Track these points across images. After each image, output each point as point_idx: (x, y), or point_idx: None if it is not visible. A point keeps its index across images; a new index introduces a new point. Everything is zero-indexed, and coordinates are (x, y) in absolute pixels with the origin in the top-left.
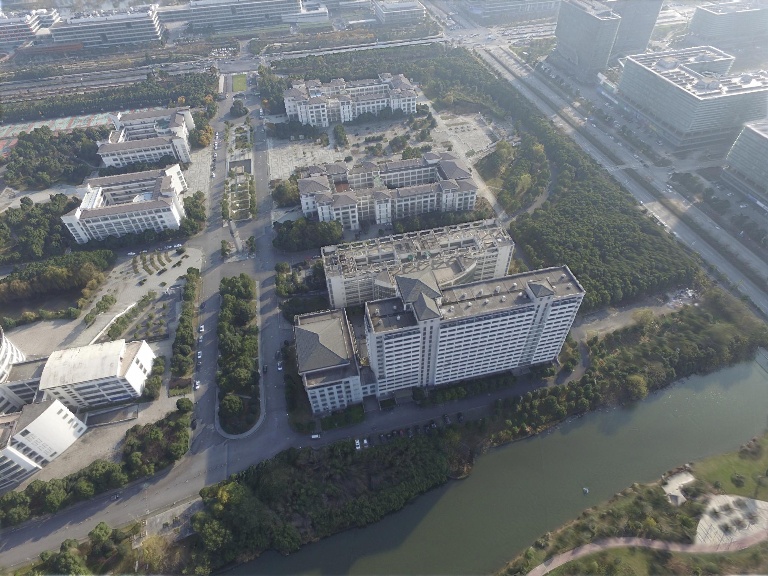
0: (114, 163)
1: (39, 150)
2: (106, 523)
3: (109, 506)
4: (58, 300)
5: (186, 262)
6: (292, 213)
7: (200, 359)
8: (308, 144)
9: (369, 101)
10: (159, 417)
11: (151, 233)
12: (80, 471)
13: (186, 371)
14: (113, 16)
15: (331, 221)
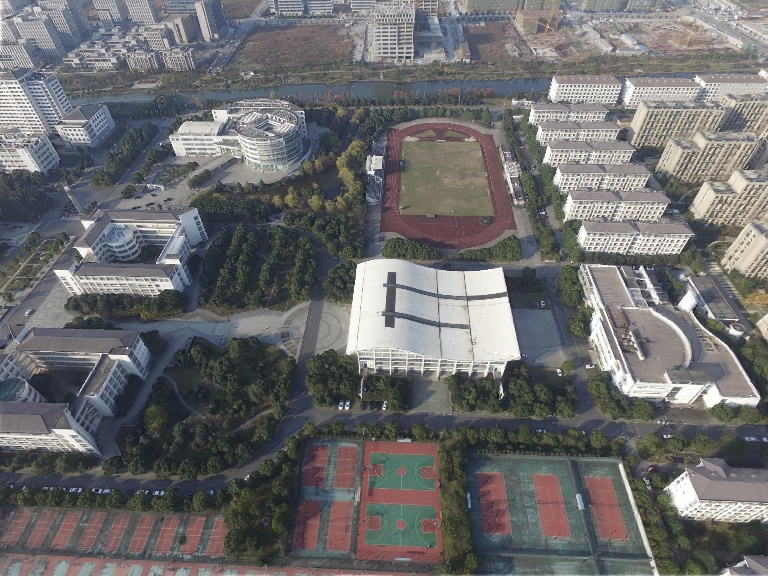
0: None
1: None
2: None
3: None
4: None
5: None
6: (5, 238)
7: None
8: None
9: None
10: None
11: None
12: None
13: None
14: None
15: None
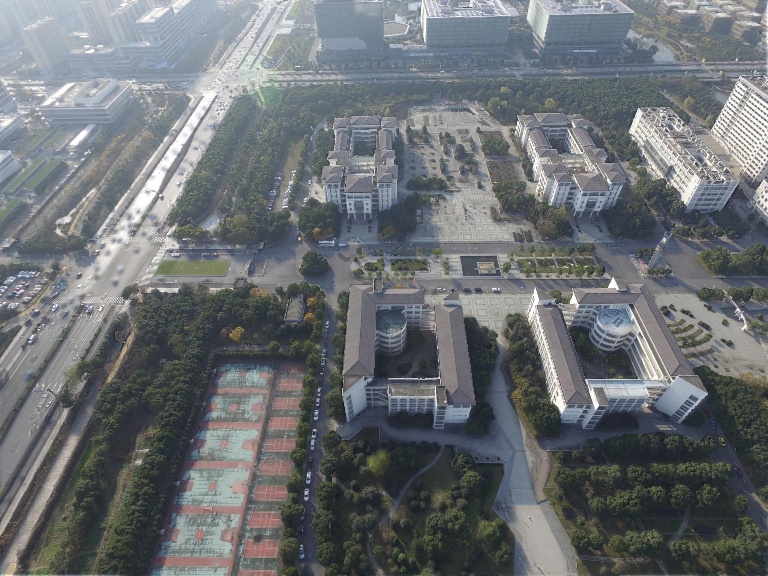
0: None
1: None
2: None
3: None
4: None
5: (682, 306)
6: (582, 228)
7: None
8: (435, 210)
9: None
10: None
11: None
12: None
13: None
14: None
15: (636, 185)
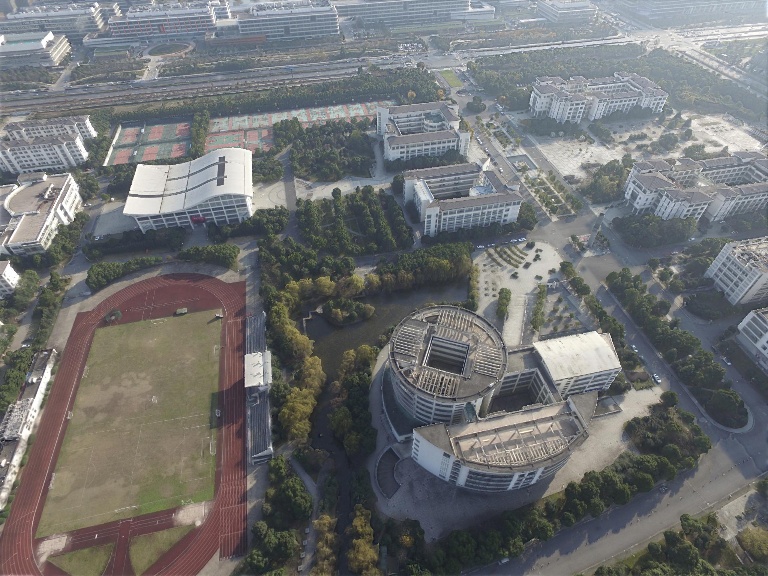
0: (399, 156)
1: (304, 141)
2: (675, 515)
3: (664, 498)
4: (440, 292)
5: (544, 256)
6: (613, 209)
7: (638, 353)
8: (572, 141)
9: (622, 99)
10: (643, 410)
11: (500, 226)
12: (619, 463)
13: (640, 364)
14: (298, 9)
15: None
